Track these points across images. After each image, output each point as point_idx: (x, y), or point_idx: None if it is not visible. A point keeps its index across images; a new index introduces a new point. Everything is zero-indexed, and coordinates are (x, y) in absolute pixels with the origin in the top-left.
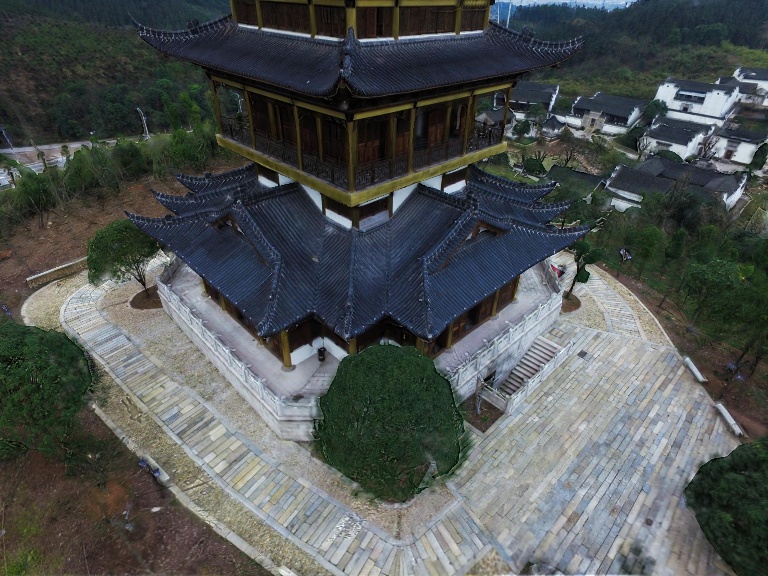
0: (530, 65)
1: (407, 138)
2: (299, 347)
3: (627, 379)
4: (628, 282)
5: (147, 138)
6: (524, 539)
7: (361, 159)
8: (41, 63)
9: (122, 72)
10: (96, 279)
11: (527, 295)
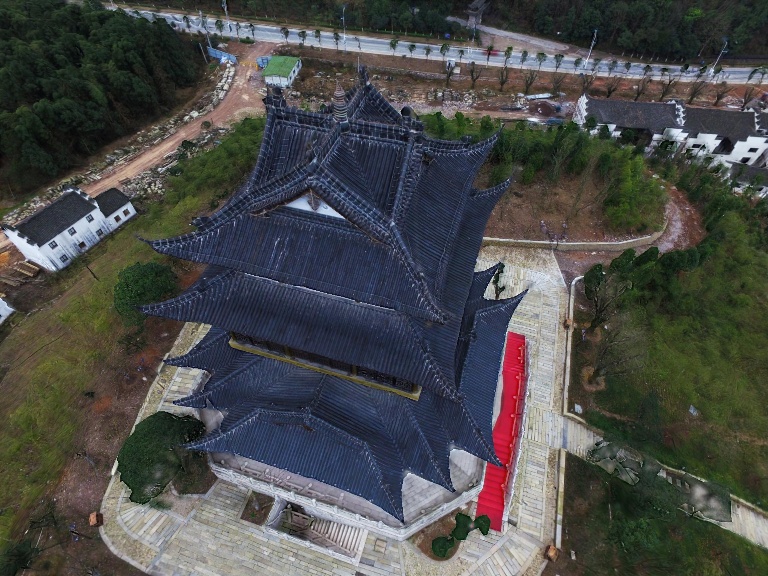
0: (393, 372)
1: None
2: None
3: None
4: None
5: (584, 63)
6: (167, 570)
7: None
8: None
9: None
10: None
11: None
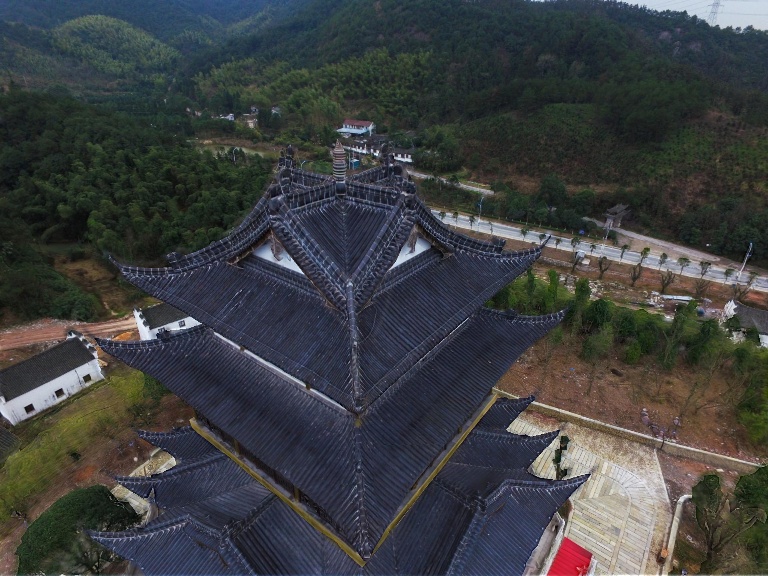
0: (310, 491)
1: None
2: None
3: None
4: None
5: (737, 274)
6: None
7: None
8: (728, 172)
9: None
10: None
11: None
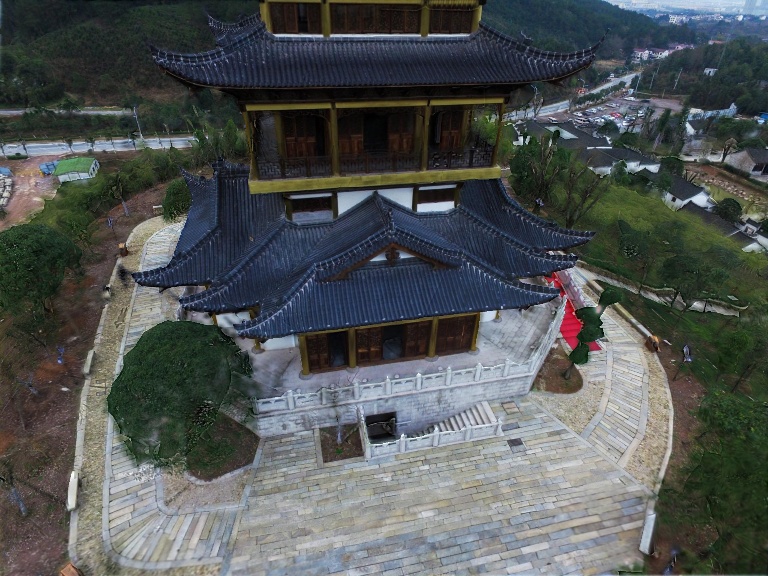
0: (503, 77)
1: (356, 141)
2: (227, 313)
3: (541, 496)
4: (685, 392)
5: None
6: (253, 575)
7: (292, 153)
8: None
9: None
10: (166, 216)
11: (496, 351)
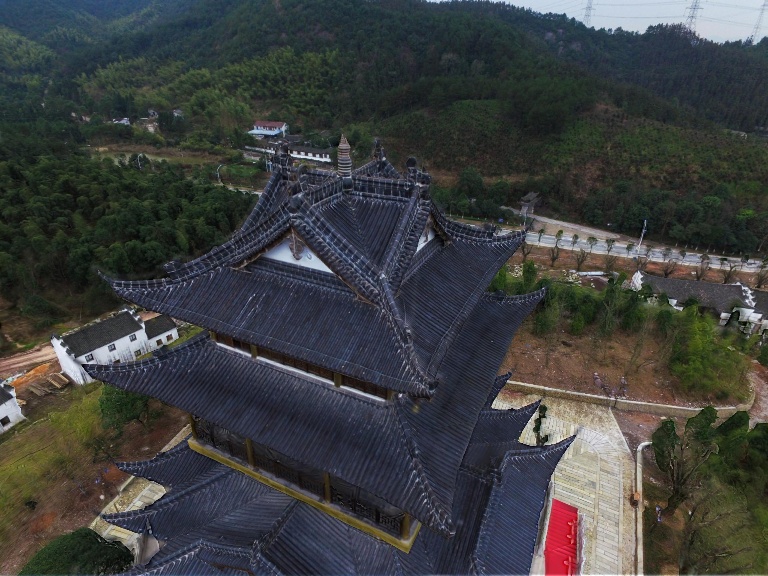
0: (366, 484)
1: None
2: None
3: None
4: None
5: (636, 248)
6: None
7: None
8: (618, 158)
9: (684, 179)
10: None
11: None
